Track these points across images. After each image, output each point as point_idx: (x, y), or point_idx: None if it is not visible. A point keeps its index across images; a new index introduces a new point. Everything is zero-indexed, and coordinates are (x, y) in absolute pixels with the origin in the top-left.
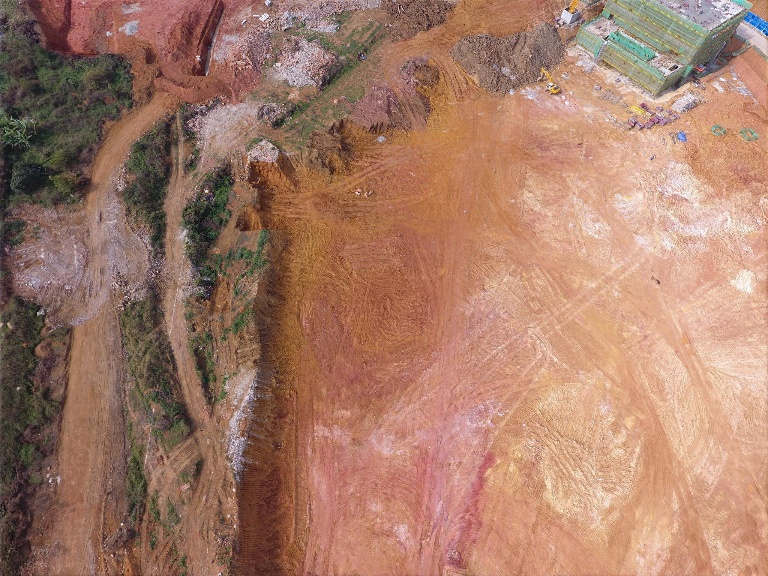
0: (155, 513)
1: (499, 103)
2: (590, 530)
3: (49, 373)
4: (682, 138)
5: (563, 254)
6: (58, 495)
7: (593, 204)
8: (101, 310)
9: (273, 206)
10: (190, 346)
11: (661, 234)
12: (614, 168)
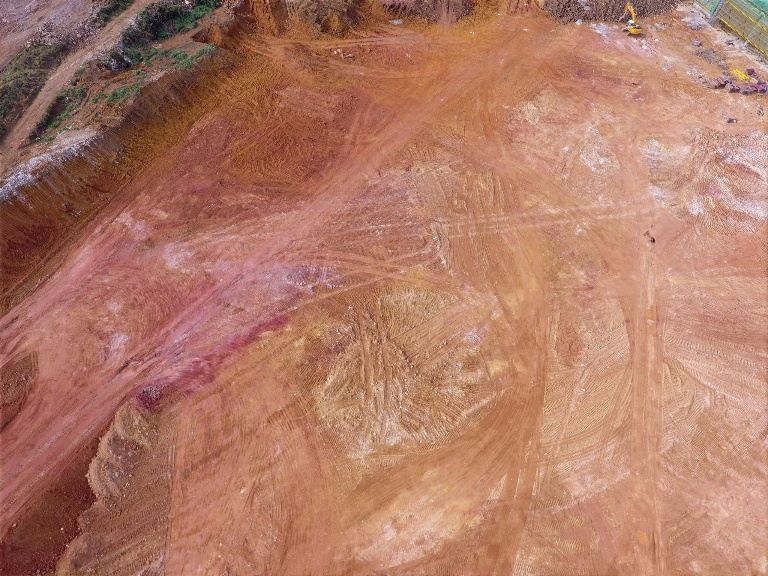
0: None
1: (556, 27)
2: (345, 457)
3: None
4: None
5: (534, 170)
6: None
7: (612, 139)
8: (13, 42)
9: (246, 39)
10: (58, 93)
11: (692, 195)
12: (667, 116)
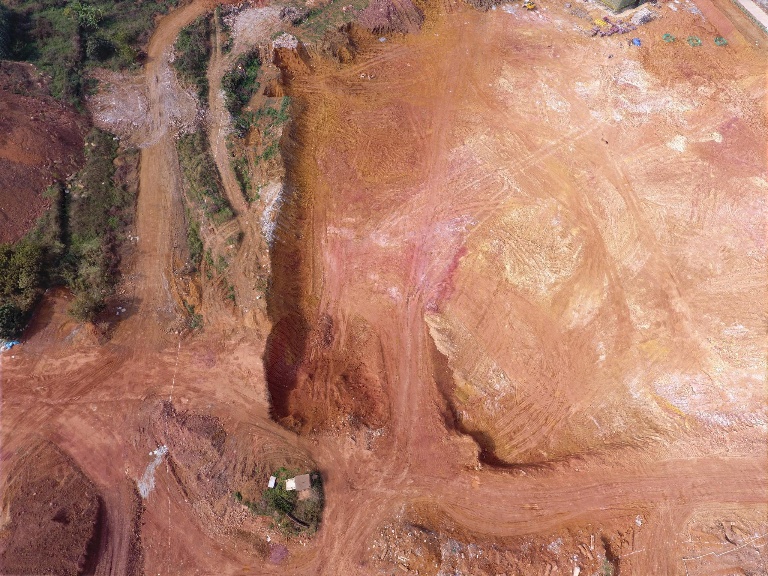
0: (210, 260)
1: (483, 15)
2: (538, 295)
3: (125, 176)
4: (637, 43)
5: (530, 122)
6: (138, 247)
7: (557, 88)
8: (162, 139)
9: (293, 84)
10: (231, 165)
11: (612, 110)
12: (577, 64)
